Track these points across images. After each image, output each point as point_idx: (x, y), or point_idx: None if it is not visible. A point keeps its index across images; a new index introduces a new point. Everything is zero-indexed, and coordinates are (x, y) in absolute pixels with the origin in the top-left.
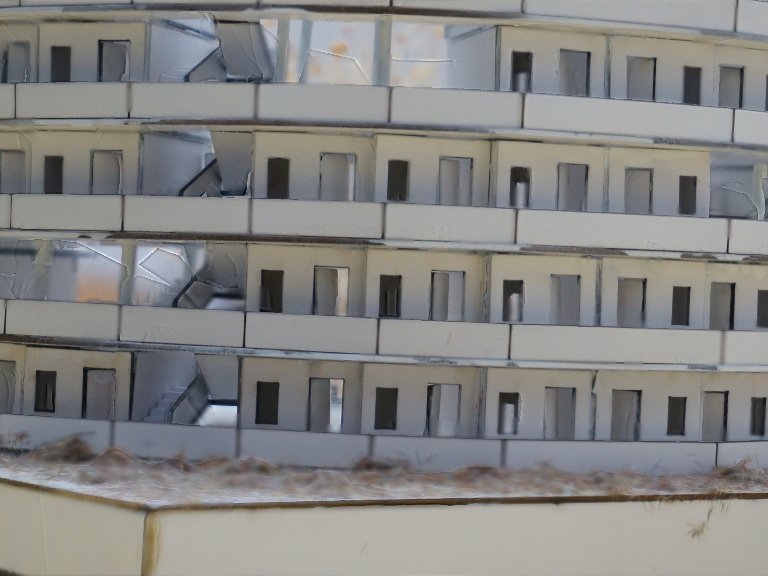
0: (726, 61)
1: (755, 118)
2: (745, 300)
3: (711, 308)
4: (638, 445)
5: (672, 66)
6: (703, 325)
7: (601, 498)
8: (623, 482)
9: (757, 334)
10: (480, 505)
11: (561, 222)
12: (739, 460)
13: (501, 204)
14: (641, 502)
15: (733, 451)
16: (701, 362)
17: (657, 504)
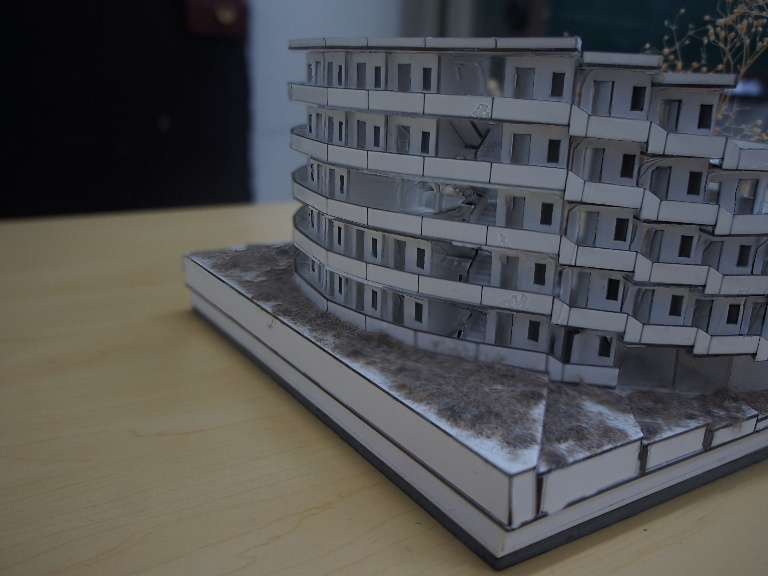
0: (360, 118)
1: (336, 150)
2: (368, 241)
3: (359, 241)
4: (311, 290)
5: (336, 121)
6: (353, 248)
7: (248, 298)
8: (262, 296)
9: (340, 257)
10: (224, 284)
11: (298, 189)
12: (338, 313)
13: (309, 179)
14: (255, 305)
15: (333, 307)
16: (323, 262)
17: (259, 309)
